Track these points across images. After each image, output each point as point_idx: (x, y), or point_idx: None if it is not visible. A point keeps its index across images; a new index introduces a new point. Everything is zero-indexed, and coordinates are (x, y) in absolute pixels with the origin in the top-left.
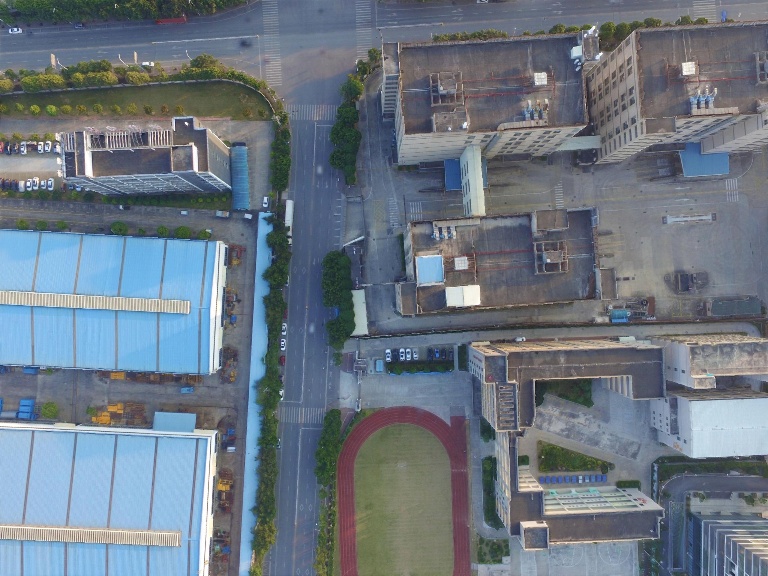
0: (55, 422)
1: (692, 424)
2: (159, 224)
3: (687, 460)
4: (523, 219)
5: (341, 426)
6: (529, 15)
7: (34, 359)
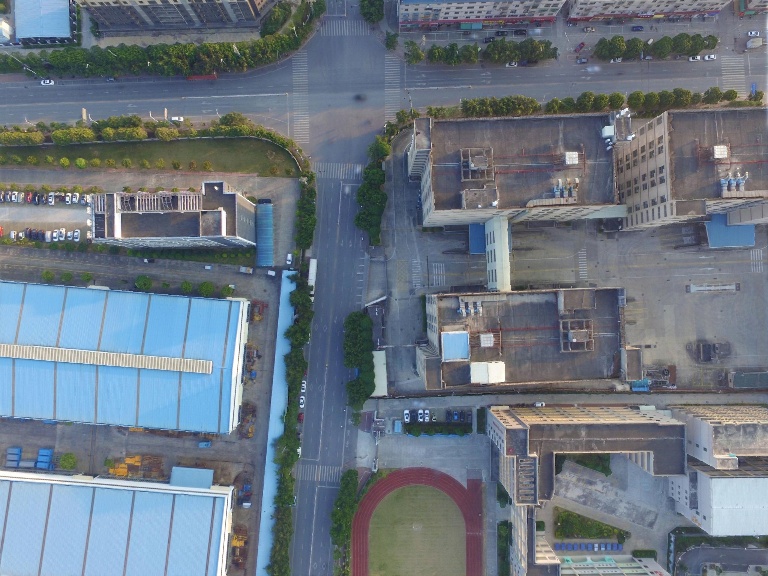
0: (73, 473)
1: (712, 502)
2: (183, 278)
3: (704, 532)
4: (550, 296)
5: None
6: (558, 80)
7: (56, 413)
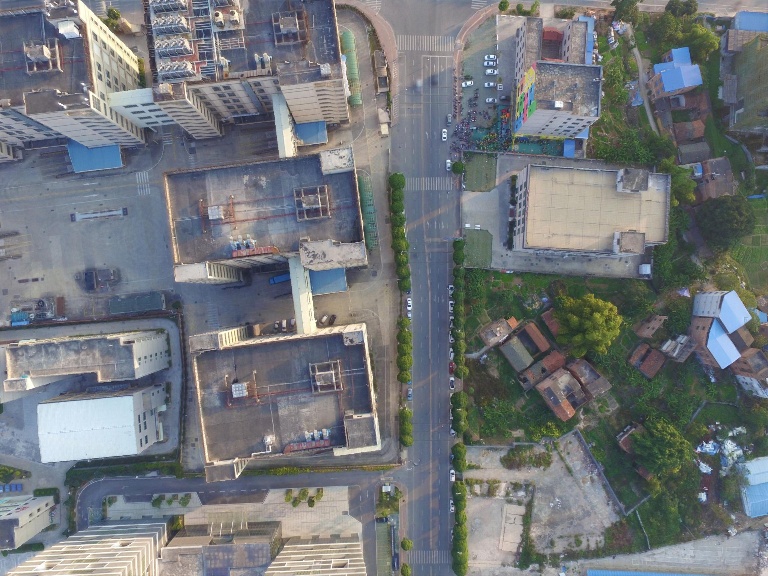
0: None
1: (38, 428)
2: None
3: (102, 464)
4: None
5: None
6: None
7: None
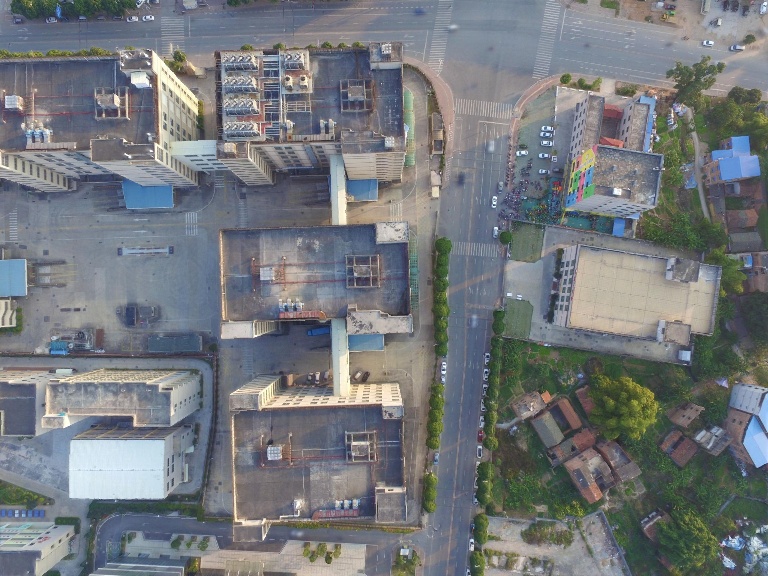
0: None
1: (69, 463)
2: None
3: None
4: None
5: None
6: None
7: None
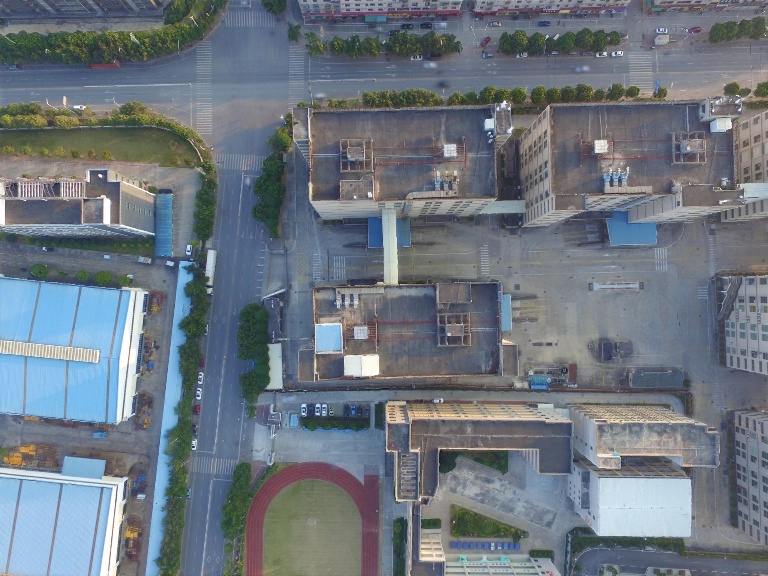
0: None
1: (600, 501)
2: (82, 267)
3: None
4: (428, 289)
5: (253, 479)
6: (463, 74)
7: None
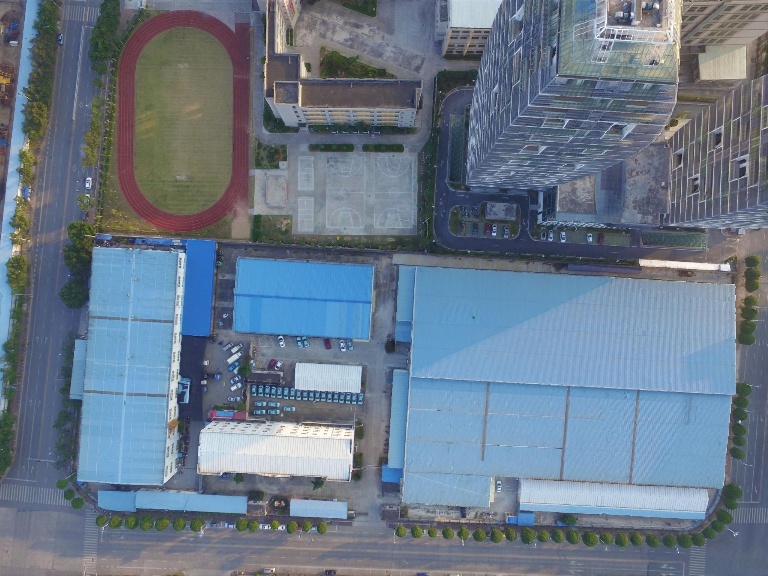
0: None
1: None
2: None
3: None
4: None
5: (125, 27)
6: None
7: None
